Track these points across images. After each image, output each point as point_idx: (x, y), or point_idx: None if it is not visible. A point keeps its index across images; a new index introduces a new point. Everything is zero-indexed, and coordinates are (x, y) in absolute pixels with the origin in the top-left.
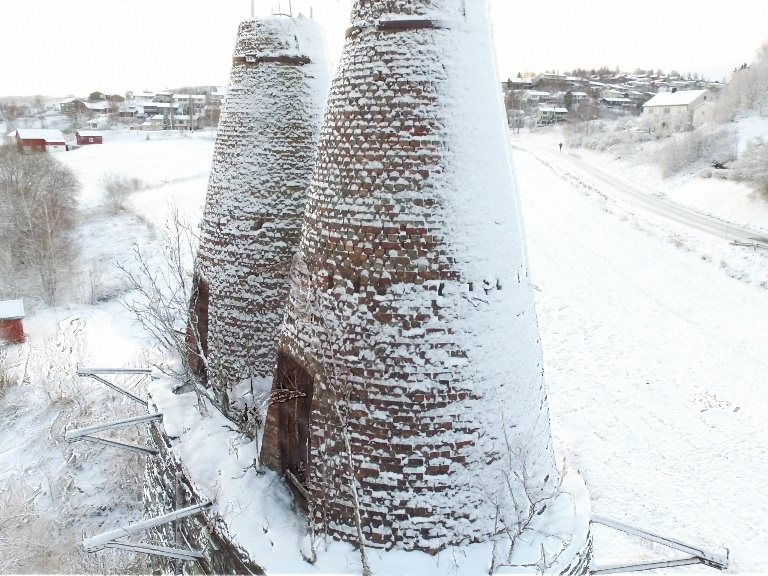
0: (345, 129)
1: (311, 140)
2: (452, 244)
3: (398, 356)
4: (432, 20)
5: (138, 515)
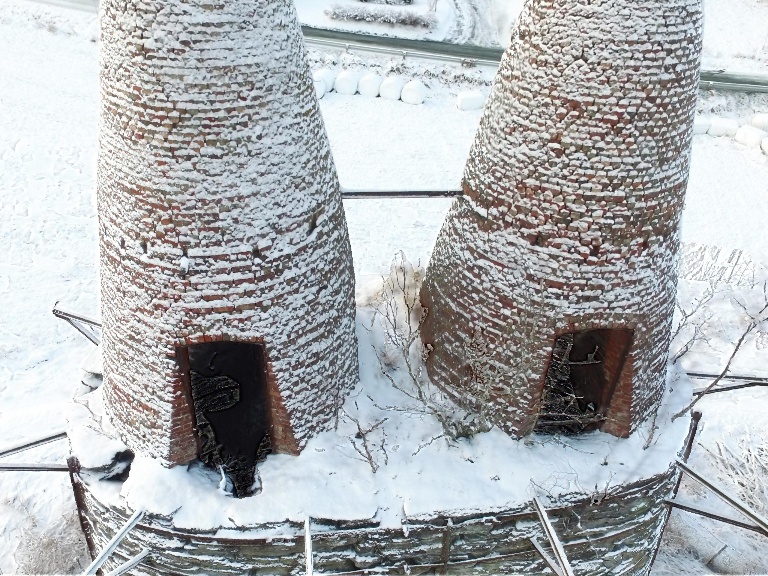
0: (663, 99)
1: (312, 80)
2: None
3: None
4: None
5: None
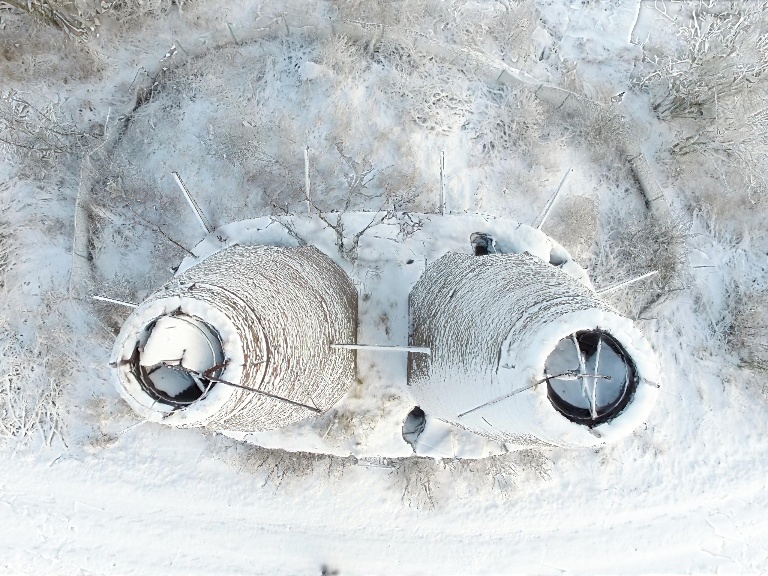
0: None
1: None
2: None
3: None
4: None
5: (759, 288)
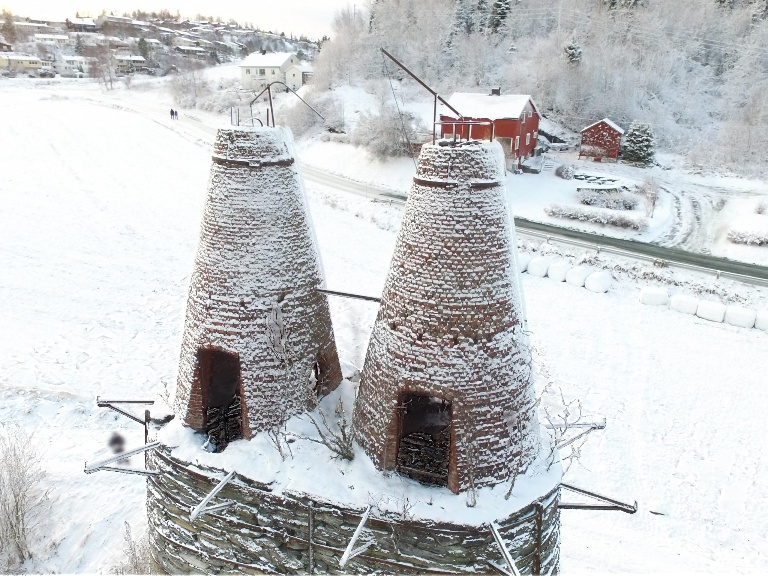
0: (456, 248)
1: (304, 223)
2: (516, 305)
3: (502, 374)
4: (498, 182)
5: None
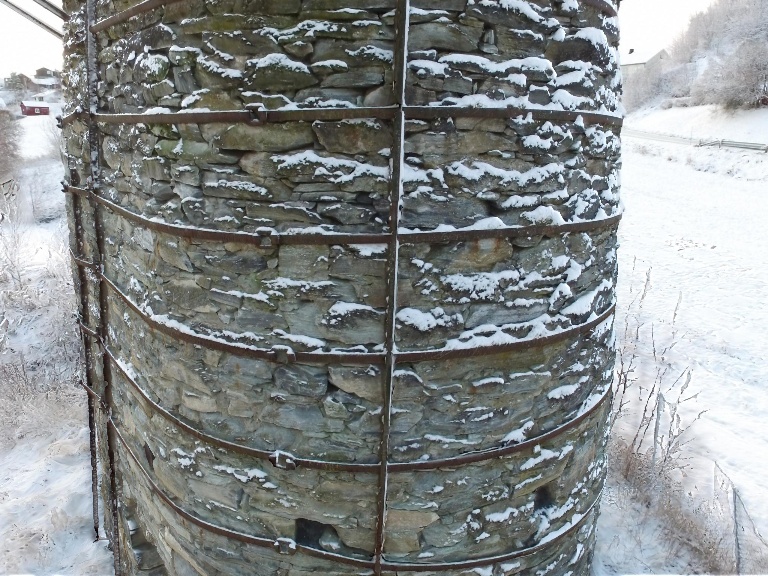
0: None
1: None
2: None
3: None
4: None
5: None
